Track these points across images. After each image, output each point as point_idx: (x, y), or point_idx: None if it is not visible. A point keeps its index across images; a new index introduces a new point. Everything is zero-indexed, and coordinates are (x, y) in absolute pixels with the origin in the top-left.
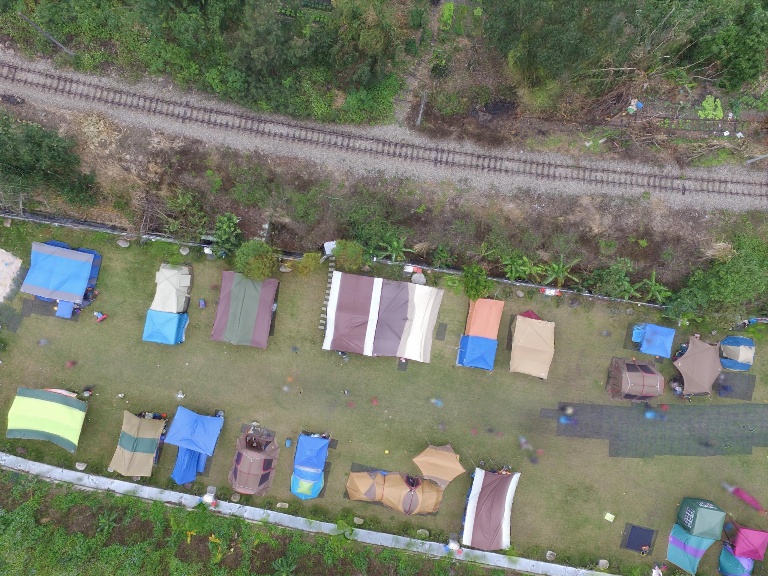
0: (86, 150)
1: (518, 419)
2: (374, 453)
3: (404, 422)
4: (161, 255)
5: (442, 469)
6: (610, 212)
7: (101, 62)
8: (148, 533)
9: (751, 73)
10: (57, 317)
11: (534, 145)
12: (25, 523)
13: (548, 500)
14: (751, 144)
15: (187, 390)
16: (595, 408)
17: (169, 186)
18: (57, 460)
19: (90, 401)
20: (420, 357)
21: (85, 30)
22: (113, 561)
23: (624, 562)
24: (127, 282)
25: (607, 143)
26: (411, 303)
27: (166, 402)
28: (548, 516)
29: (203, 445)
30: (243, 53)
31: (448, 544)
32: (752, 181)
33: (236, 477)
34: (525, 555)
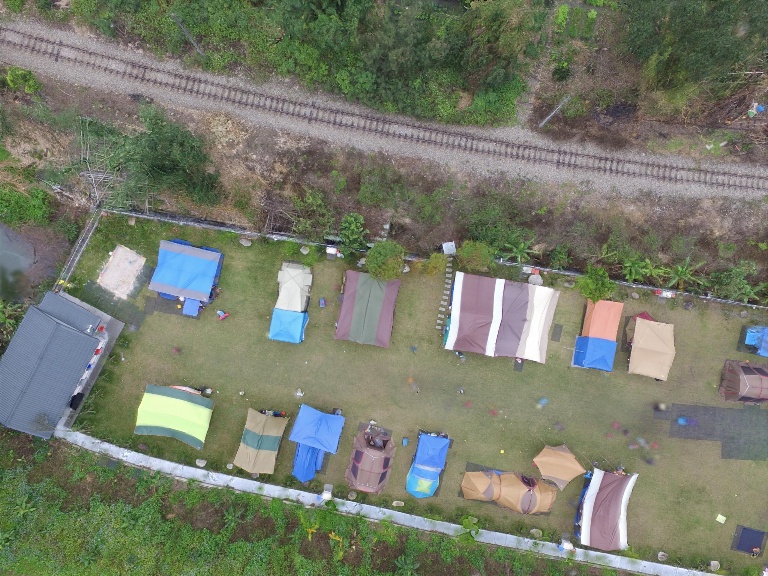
0: (213, 150)
1: (632, 420)
2: (489, 453)
3: (519, 422)
4: (282, 254)
5: (561, 469)
6: (730, 215)
7: (230, 62)
8: (270, 530)
9: None
10: (179, 315)
11: (655, 148)
12: (152, 519)
13: (660, 501)
14: None
15: (306, 388)
16: (708, 410)
17: (293, 186)
18: (177, 457)
19: (211, 398)
20: None
21: (215, 31)
22: (240, 557)
23: (735, 564)
24: (248, 281)
25: (728, 146)
26: (530, 304)
27: (285, 400)
28: (660, 517)
29: (327, 443)
30: (379, 55)
31: (561, 544)
32: None
33: (356, 475)
34: (636, 556)
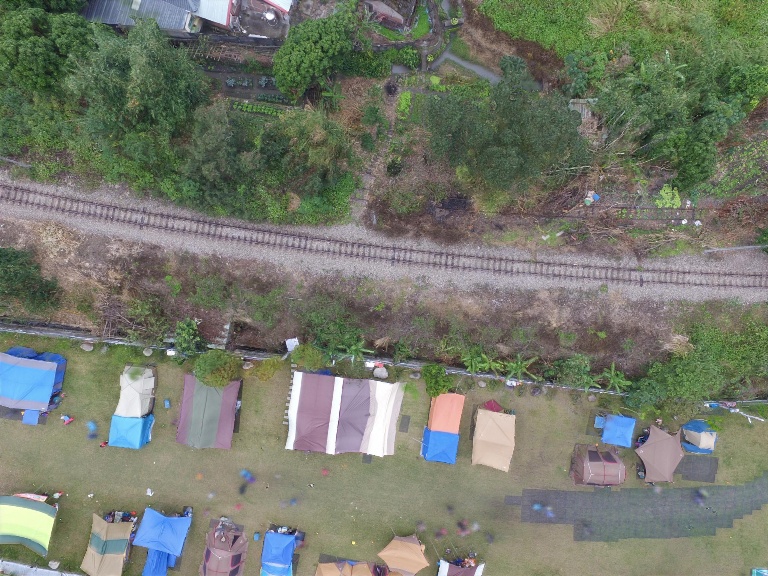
0: (46, 259)
1: (483, 507)
2: (341, 544)
3: (370, 513)
4: (125, 357)
5: (407, 562)
6: (568, 305)
7: (57, 172)
8: None
9: (702, 177)
10: None
11: (491, 240)
12: None
13: None
14: (709, 233)
15: (155, 488)
16: (559, 494)
17: (130, 291)
18: (30, 559)
19: (60, 502)
20: (383, 453)
21: (40, 142)
22: None
23: None
24: (92, 384)
25: (564, 236)
26: (373, 399)
27: (135, 500)
28: None
29: (171, 546)
30: (195, 167)
31: None
32: (710, 271)
33: (205, 574)
34: None
